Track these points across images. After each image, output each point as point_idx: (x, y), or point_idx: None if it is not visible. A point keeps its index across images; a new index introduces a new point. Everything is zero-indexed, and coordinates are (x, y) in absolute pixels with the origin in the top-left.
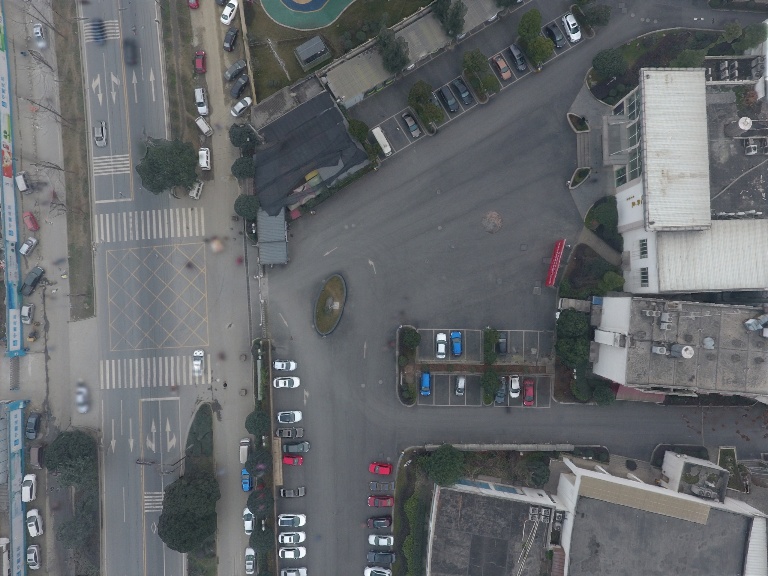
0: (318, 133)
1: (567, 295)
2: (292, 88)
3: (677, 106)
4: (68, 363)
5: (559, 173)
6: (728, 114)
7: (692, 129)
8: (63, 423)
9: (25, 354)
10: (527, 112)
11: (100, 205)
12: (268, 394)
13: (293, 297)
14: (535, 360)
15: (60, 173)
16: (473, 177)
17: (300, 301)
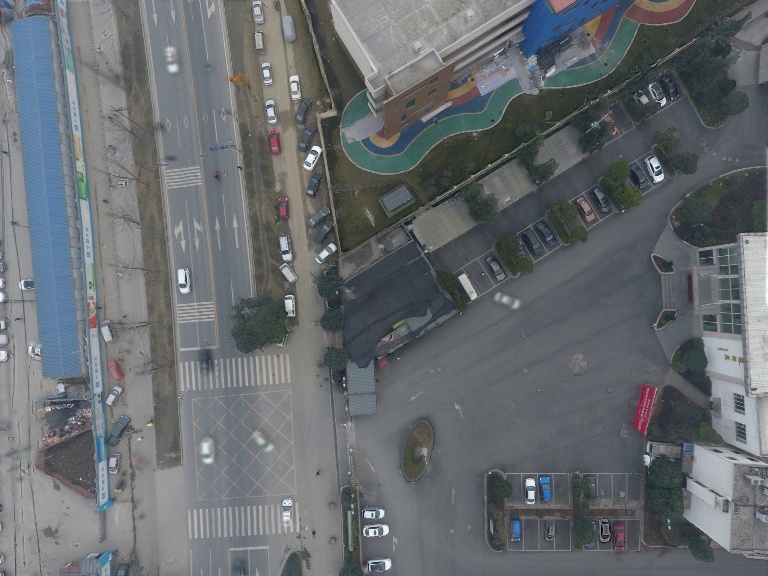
0: (406, 283)
1: (656, 439)
2: (378, 237)
3: None
4: (155, 512)
5: (644, 314)
6: None
7: None
8: (151, 573)
9: (112, 504)
10: (611, 253)
11: (185, 353)
12: (358, 543)
13: (380, 443)
14: (624, 503)
15: (148, 327)
16: (558, 319)
17: (387, 447)
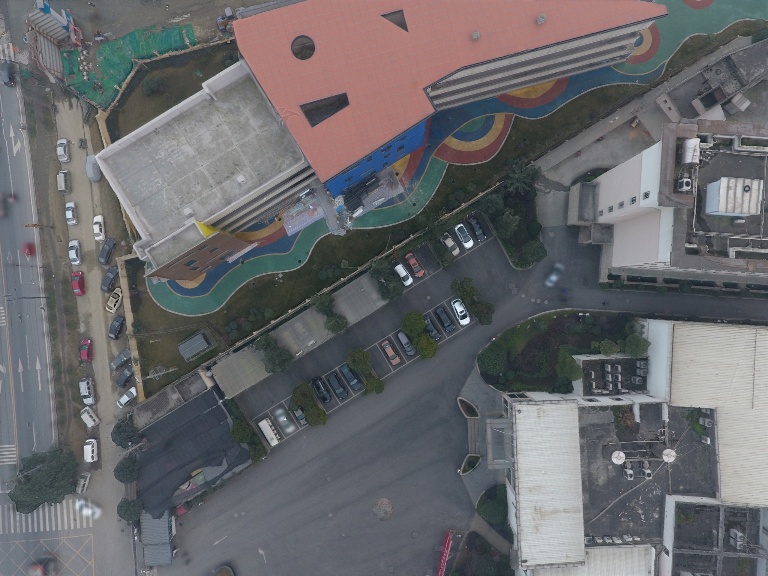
0: (202, 432)
1: None
2: (176, 384)
3: (549, 440)
4: None
5: (450, 458)
6: (606, 434)
7: (565, 463)
8: None
9: None
10: (417, 396)
11: None
12: None
13: None
14: None
15: None
16: (363, 463)
17: None
